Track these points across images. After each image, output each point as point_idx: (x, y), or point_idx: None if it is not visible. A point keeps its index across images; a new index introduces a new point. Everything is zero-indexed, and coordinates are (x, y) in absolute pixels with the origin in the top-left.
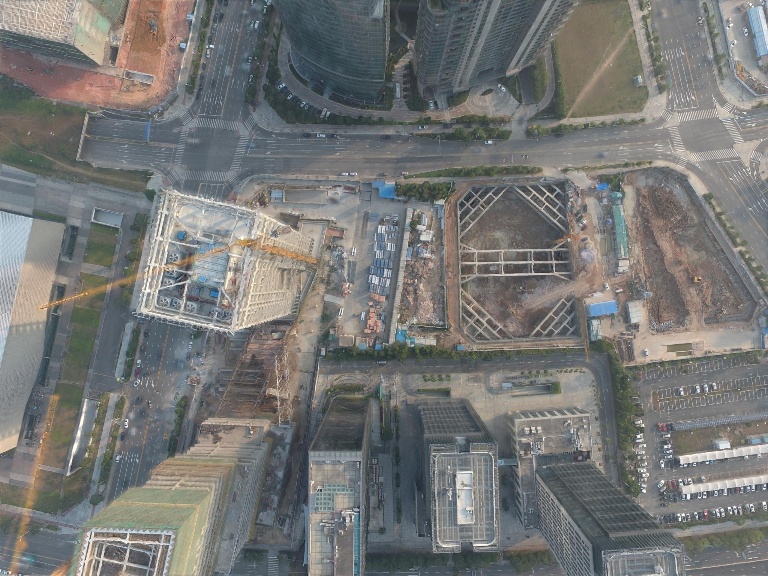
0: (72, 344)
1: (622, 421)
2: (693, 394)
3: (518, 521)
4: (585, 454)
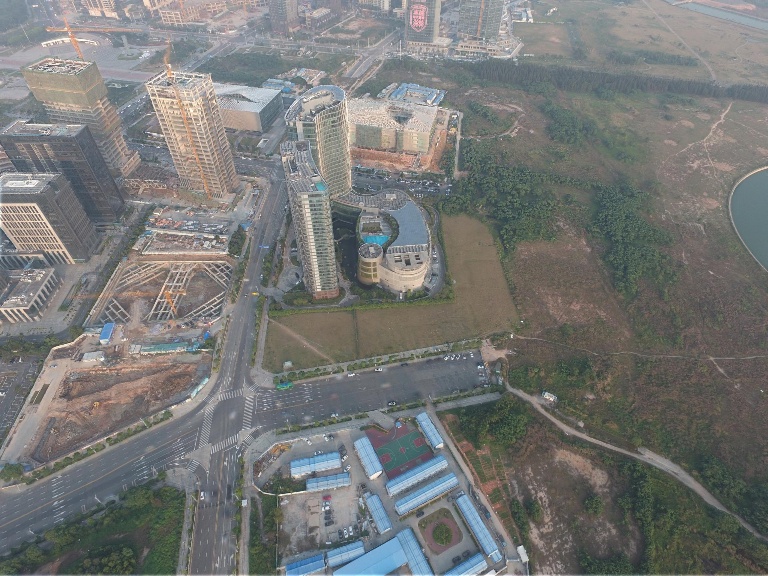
0: None
1: None
2: None
3: None
4: None
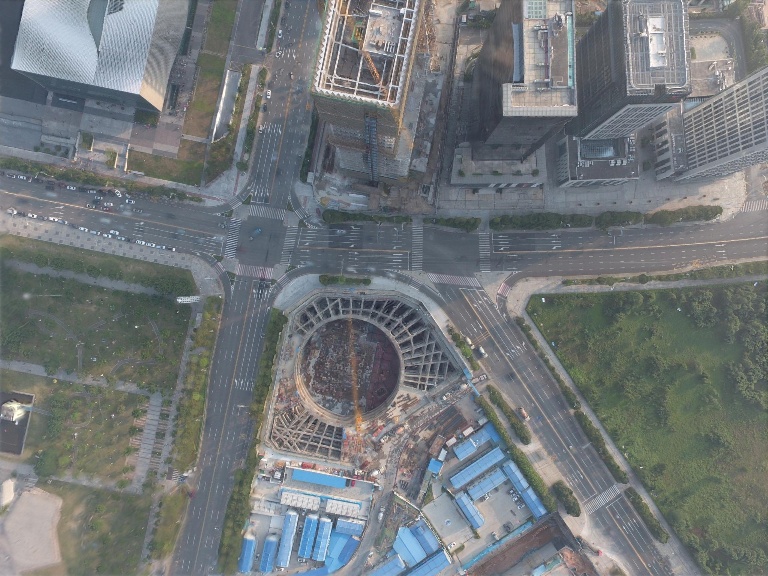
0: (214, 14)
1: None
2: None
3: (658, 184)
4: None
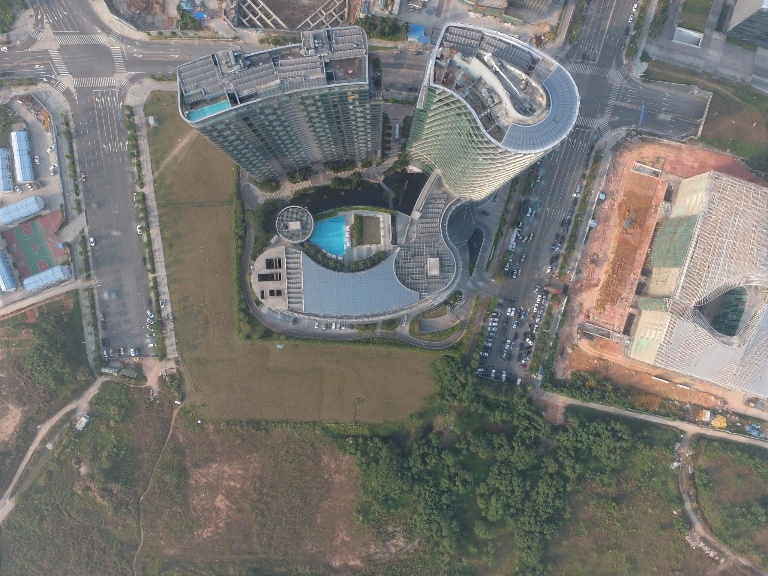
0: None
1: None
2: None
3: None
4: None
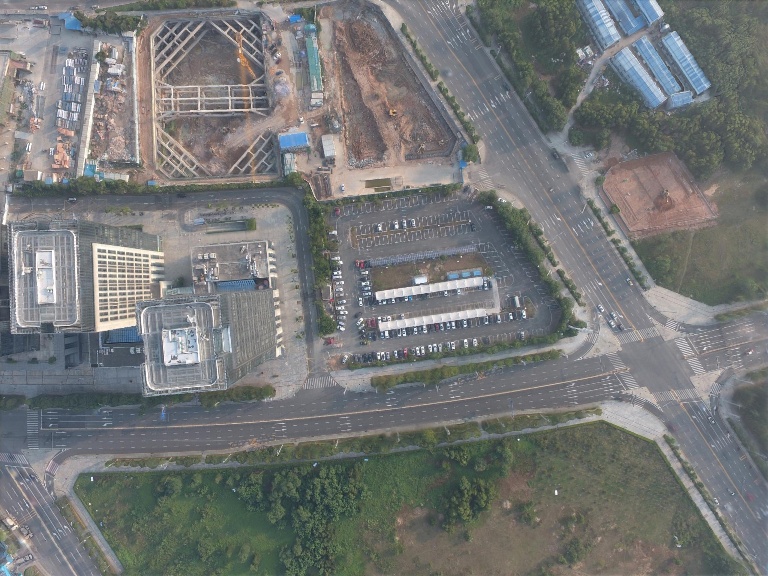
0: None
1: (317, 256)
2: (392, 230)
3: None
4: (266, 283)
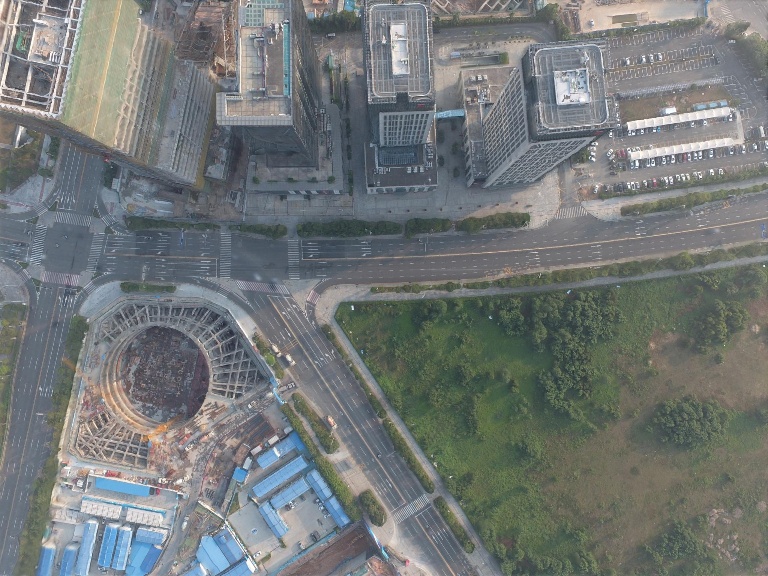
0: None
1: None
2: (639, 64)
3: (469, 191)
4: None
